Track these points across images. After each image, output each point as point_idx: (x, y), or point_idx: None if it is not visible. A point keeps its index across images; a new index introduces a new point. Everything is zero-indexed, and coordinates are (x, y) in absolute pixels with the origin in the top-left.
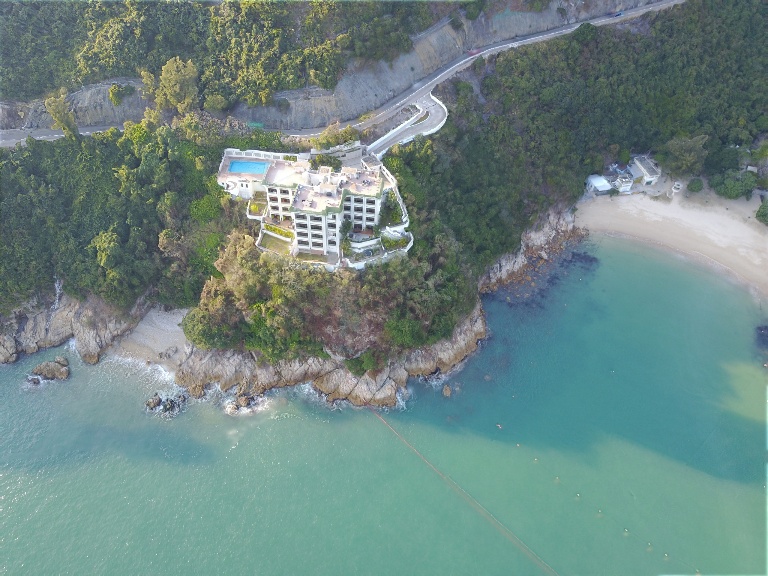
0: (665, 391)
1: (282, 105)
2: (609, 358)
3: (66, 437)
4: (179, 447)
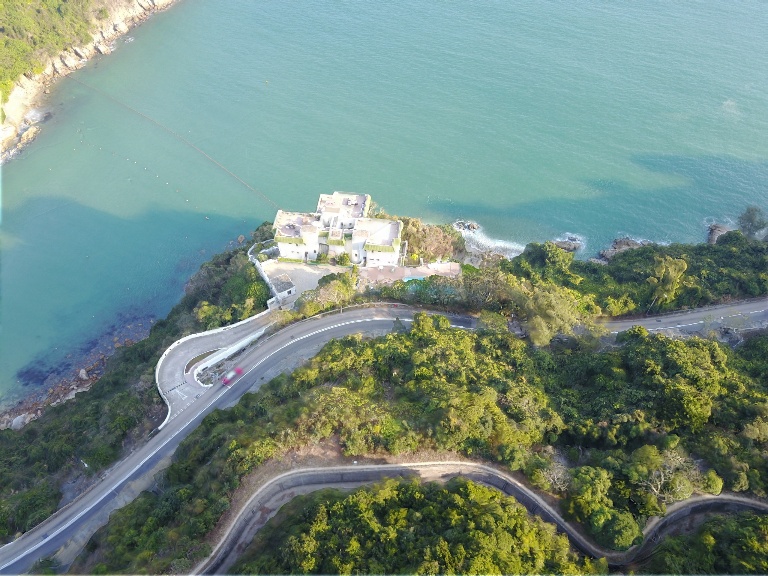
0: (53, 242)
1: (400, 324)
2: (83, 269)
3: (524, 207)
4: (444, 205)
